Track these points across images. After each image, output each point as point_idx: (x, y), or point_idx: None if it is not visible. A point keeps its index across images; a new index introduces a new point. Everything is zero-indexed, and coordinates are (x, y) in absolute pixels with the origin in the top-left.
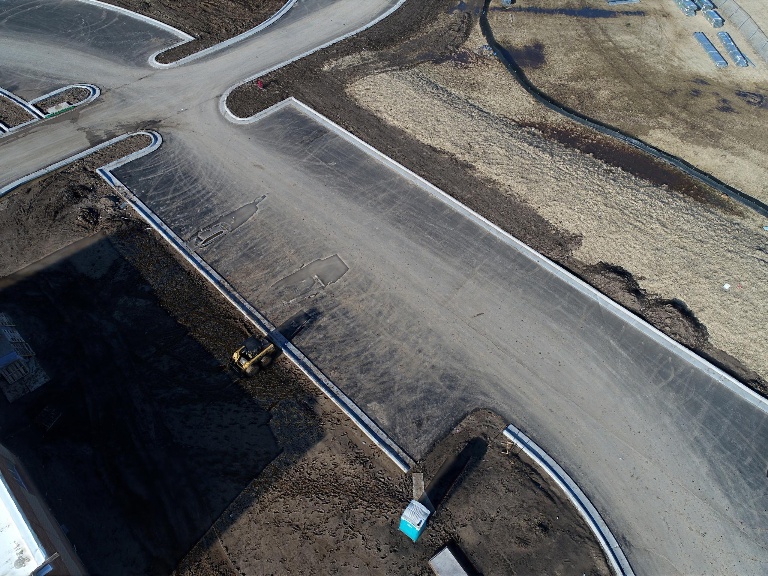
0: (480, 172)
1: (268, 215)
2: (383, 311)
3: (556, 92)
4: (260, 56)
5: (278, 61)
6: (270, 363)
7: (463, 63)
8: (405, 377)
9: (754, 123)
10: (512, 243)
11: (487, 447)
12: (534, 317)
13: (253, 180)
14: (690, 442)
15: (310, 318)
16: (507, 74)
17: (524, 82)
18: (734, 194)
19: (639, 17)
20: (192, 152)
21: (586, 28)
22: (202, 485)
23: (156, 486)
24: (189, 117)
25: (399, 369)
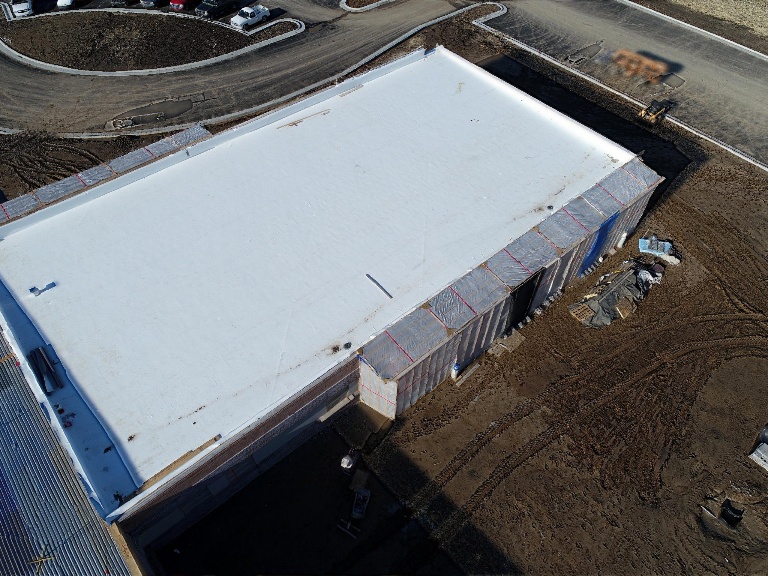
0: (758, 32)
1: (611, 51)
2: (721, 103)
3: None
4: None
5: None
6: (660, 122)
7: None
8: (753, 134)
9: None
10: None
11: None
12: None
13: (588, 32)
14: None
15: (673, 103)
16: None
17: None
18: None
19: None
20: (533, 15)
21: None
22: None
23: None
24: None
25: (747, 131)
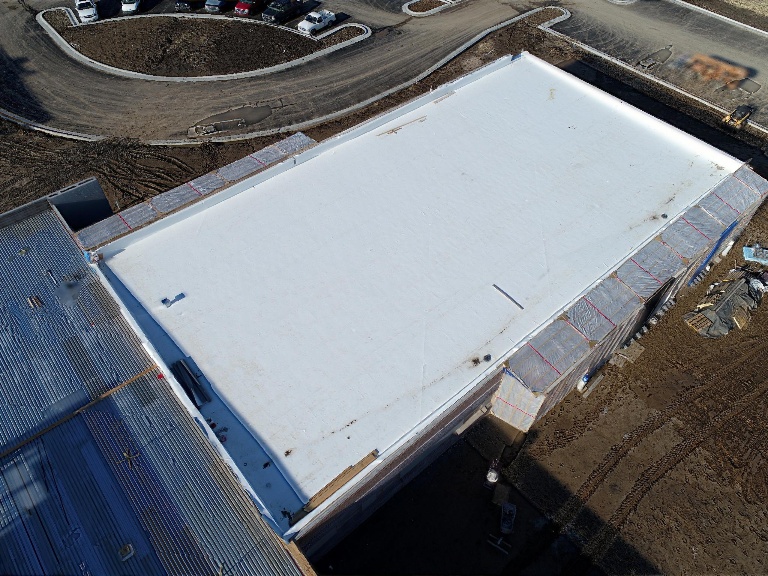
0: None
1: (682, 55)
2: None
3: None
4: None
5: None
6: (743, 128)
7: None
8: None
9: None
10: None
11: None
12: None
13: (656, 36)
14: None
15: (753, 109)
16: None
17: None
18: None
19: None
20: (598, 19)
21: None
22: None
23: None
24: None
25: None
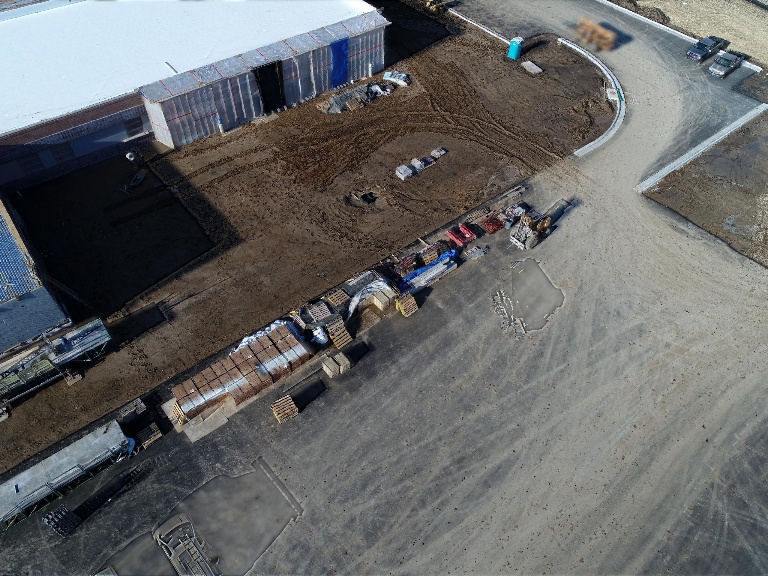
0: None
1: None
2: (498, 4)
3: None
4: None
5: None
6: (443, 13)
7: None
8: (510, 22)
9: None
10: None
11: (549, 43)
12: (577, 10)
13: None
14: (650, 47)
15: (460, 3)
16: None
17: None
18: None
19: None
20: None
21: None
22: (418, 39)
23: (397, 37)
24: None
25: (507, 20)
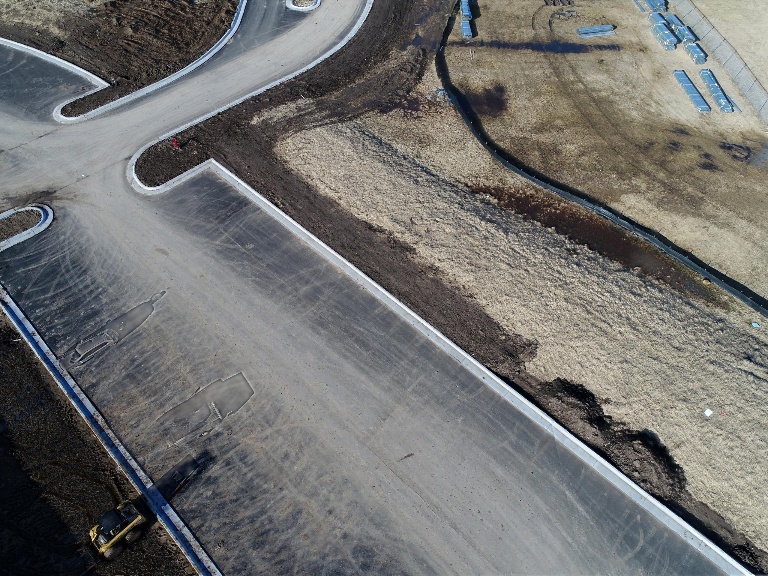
0: (421, 257)
1: (165, 318)
2: (290, 453)
3: (517, 147)
4: (182, 106)
5: (202, 112)
6: (139, 537)
7: (413, 112)
8: (308, 552)
9: (740, 184)
10: (453, 353)
11: None
12: (474, 459)
13: (153, 270)
14: None
15: (198, 466)
16: (462, 125)
17: (481, 135)
18: (717, 280)
19: (613, 52)
20: (86, 233)
21: (554, 66)
22: None
23: None
24: (89, 186)
25: (302, 540)
